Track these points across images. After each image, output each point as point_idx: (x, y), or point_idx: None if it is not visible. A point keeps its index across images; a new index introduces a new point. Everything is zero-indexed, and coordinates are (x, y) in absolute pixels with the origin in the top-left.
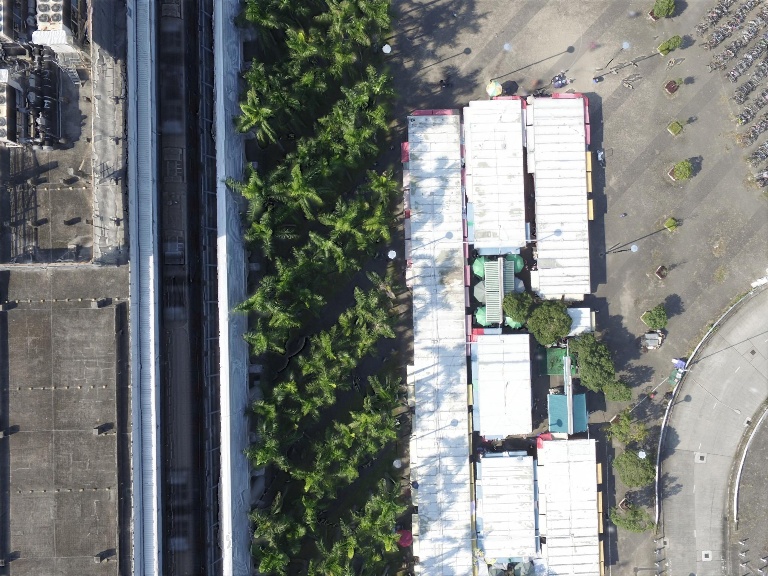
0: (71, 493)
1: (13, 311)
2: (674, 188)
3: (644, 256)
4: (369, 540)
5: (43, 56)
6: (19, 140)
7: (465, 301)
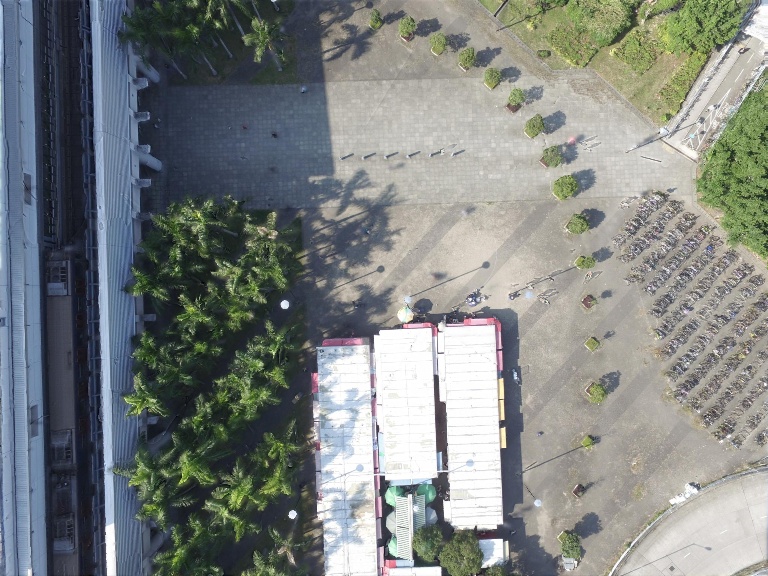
0: None
1: None
2: (591, 405)
3: (561, 475)
4: None
5: None
6: None
7: (376, 534)
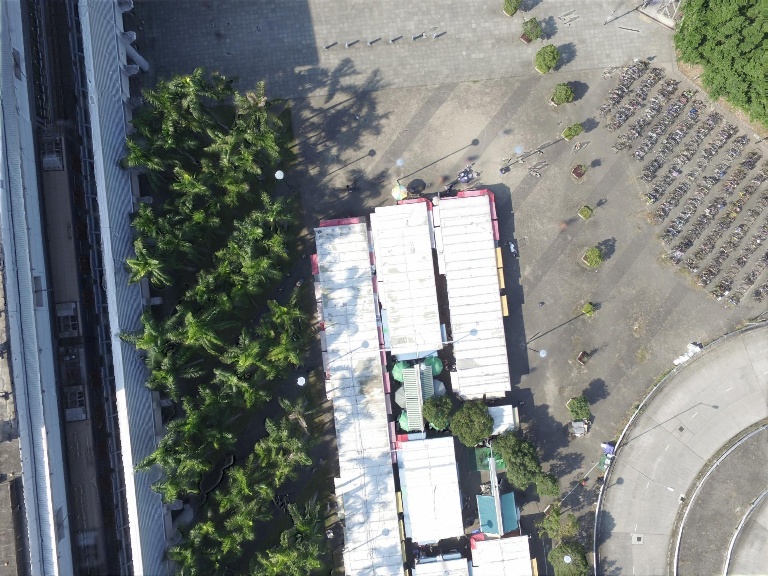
0: None
1: None
2: (589, 272)
3: (565, 343)
4: None
5: None
6: None
7: (386, 409)
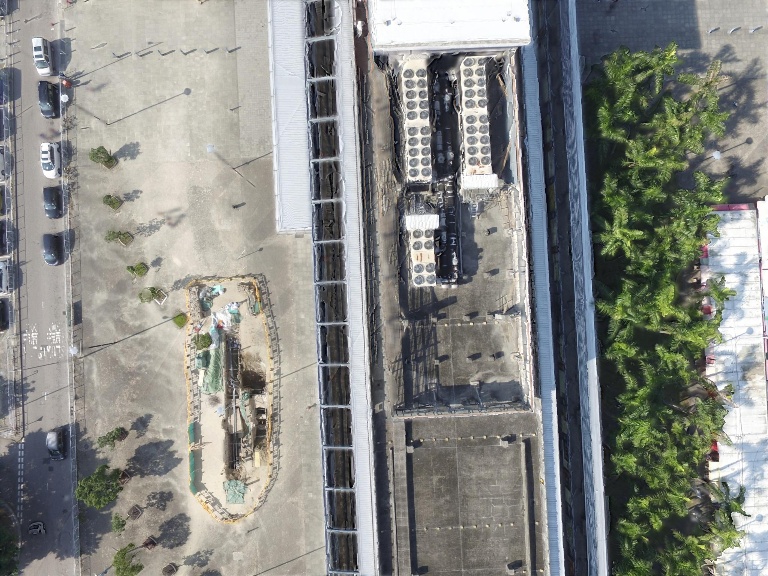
0: None
1: (418, 450)
2: None
3: None
4: None
5: (446, 191)
6: None
7: (767, 396)
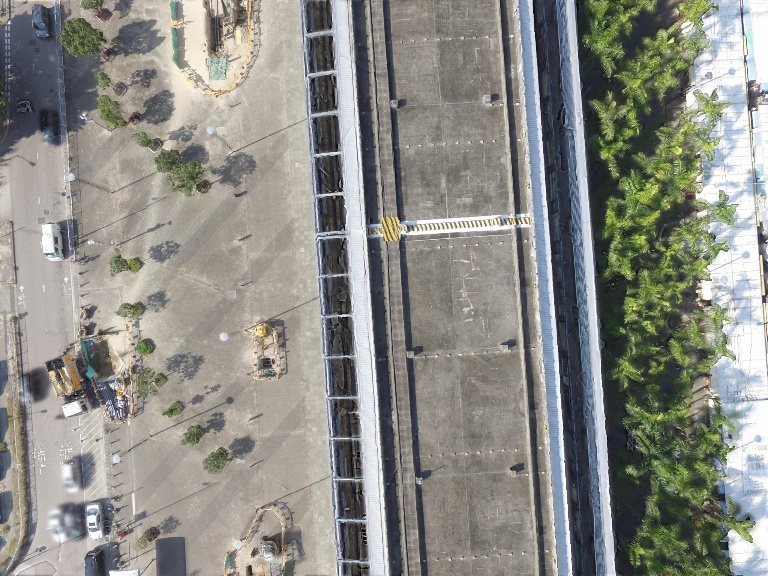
0: (452, 41)
1: None
2: None
3: None
4: None
5: None
6: None
7: None
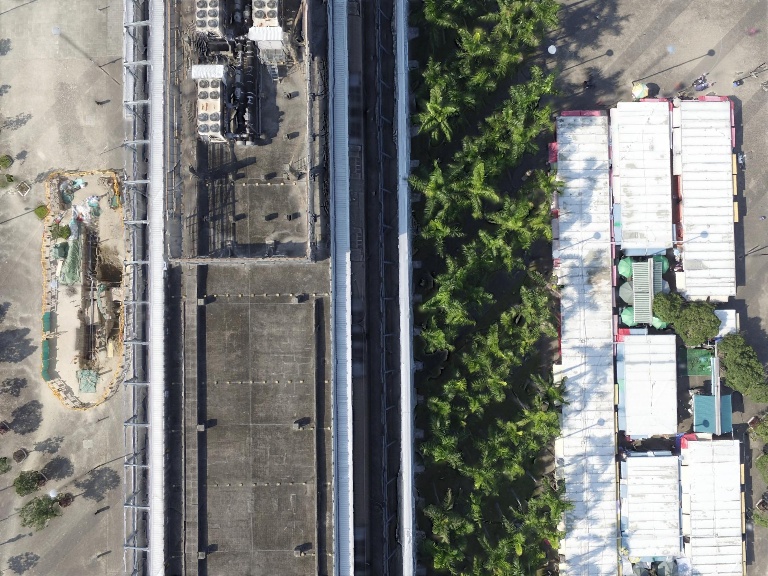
0: (268, 487)
1: (211, 305)
2: None
3: None
4: (533, 537)
5: (246, 52)
6: (226, 135)
7: (612, 301)
